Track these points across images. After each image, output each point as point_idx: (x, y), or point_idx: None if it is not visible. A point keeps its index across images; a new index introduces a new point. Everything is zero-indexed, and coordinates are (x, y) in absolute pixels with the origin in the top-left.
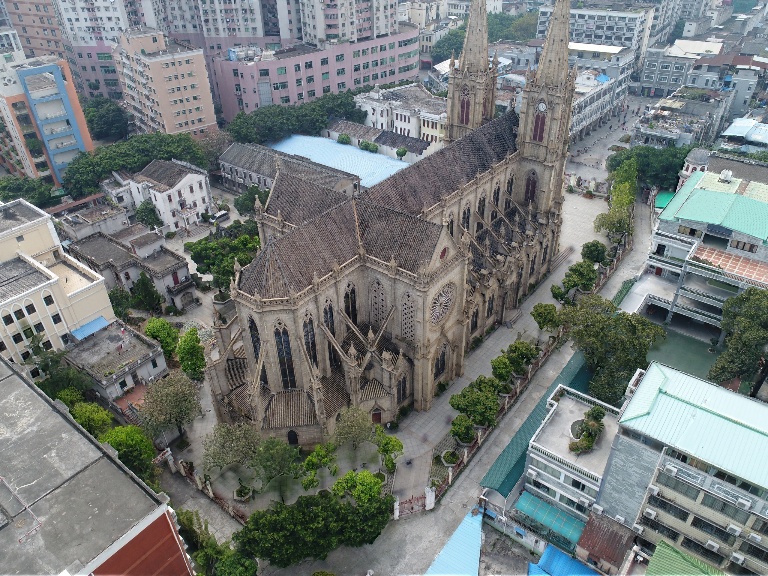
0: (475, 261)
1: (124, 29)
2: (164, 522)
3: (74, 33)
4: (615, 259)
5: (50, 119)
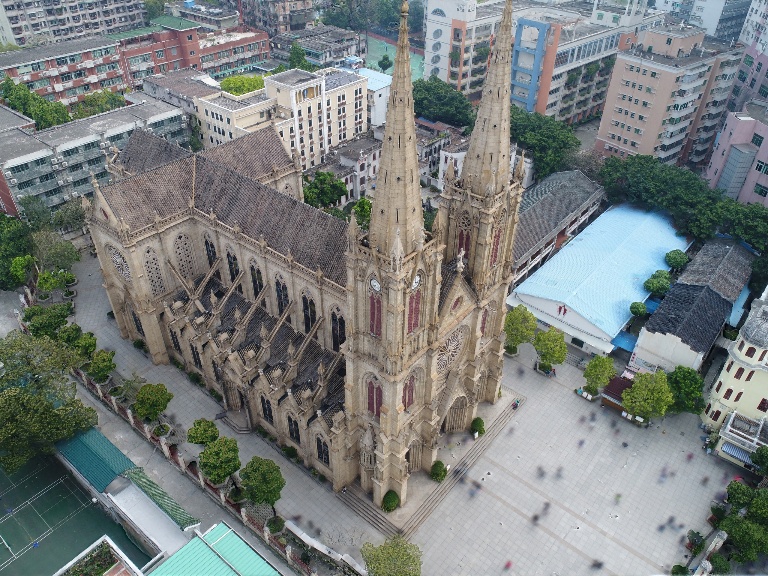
0: (251, 331)
1: (664, 20)
2: (1, 172)
3: (746, 25)
4: (312, 569)
5: (520, 68)
